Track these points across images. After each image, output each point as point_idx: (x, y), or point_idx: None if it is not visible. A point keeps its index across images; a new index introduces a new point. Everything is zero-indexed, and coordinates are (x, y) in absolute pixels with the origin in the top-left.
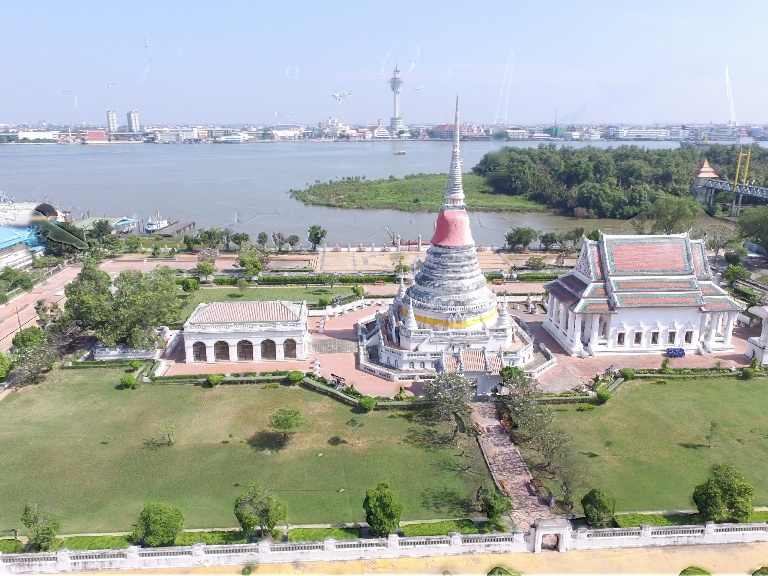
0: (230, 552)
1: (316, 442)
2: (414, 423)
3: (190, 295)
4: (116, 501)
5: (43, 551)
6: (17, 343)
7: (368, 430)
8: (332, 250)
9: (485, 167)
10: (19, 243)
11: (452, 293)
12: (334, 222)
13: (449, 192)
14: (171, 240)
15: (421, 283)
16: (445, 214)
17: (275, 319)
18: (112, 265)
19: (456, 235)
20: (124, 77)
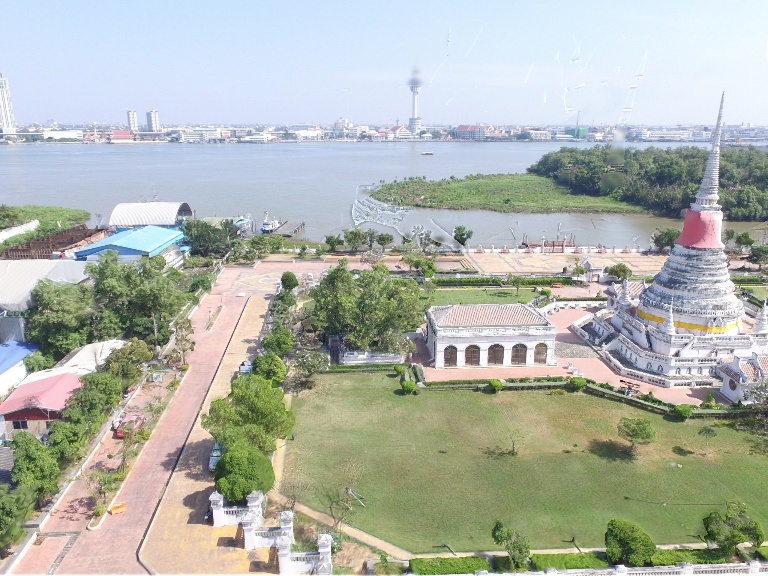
0: (718, 572)
1: (662, 452)
2: (744, 432)
3: (433, 297)
4: (518, 515)
5: (528, 570)
6: (272, 346)
7: (703, 440)
8: (475, 251)
9: (603, 168)
10: (172, 243)
11: (709, 297)
12: (439, 223)
13: (705, 193)
14: (294, 240)
15: (671, 286)
16: (701, 215)
17: (522, 323)
18: (264, 266)
19: (713, 237)
20: (423, 73)
